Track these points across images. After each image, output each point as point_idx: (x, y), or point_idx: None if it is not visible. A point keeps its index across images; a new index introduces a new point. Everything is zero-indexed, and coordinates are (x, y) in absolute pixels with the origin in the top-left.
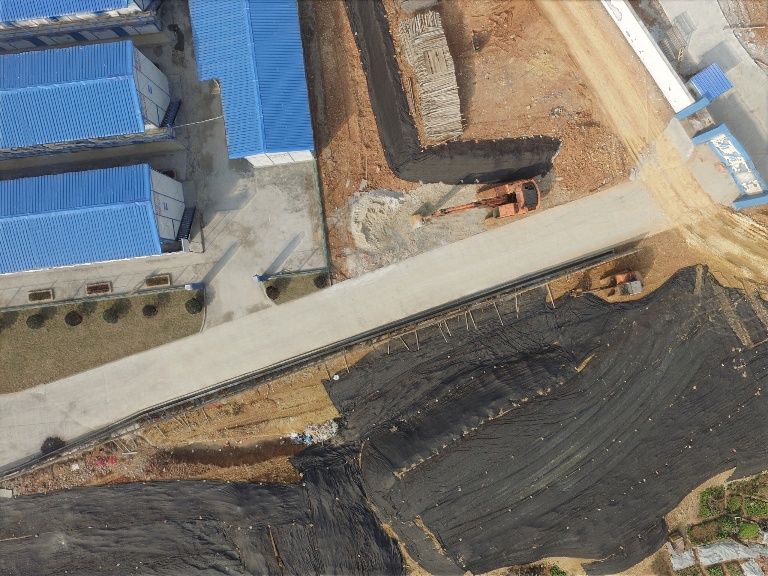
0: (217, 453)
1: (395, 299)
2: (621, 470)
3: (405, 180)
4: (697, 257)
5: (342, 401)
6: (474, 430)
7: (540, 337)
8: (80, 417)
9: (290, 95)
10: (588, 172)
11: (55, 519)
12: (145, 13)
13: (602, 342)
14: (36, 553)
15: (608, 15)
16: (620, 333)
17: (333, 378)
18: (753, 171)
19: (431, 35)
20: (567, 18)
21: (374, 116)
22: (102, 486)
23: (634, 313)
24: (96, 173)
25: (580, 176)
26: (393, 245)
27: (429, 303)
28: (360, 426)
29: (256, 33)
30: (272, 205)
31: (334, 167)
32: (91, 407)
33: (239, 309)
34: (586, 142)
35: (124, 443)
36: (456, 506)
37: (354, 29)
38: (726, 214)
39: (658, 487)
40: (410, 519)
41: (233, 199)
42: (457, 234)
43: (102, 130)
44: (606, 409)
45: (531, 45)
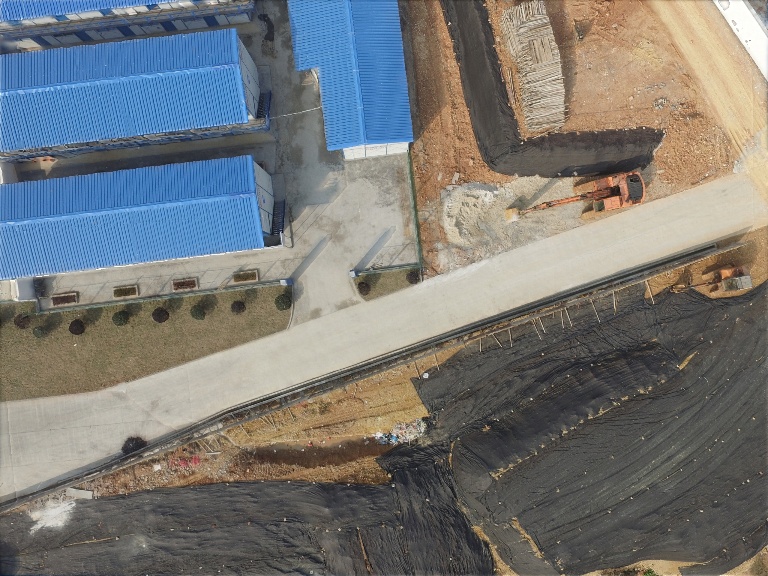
0: (300, 453)
1: (488, 295)
2: (724, 471)
3: (500, 173)
4: None
5: (432, 400)
6: (573, 429)
7: (638, 334)
8: (162, 416)
9: (390, 85)
10: (690, 165)
11: (136, 521)
12: (242, 1)
13: (705, 339)
14: (116, 556)
15: (713, 4)
16: (723, 330)
17: (423, 376)
18: None
19: (536, 24)
20: (671, 7)
21: (467, 108)
22: (185, 487)
23: (737, 309)
24: (198, 164)
25: (682, 169)
26: (486, 240)
27: (523, 299)
28: (449, 425)
29: (356, 22)
30: (363, 199)
31: (426, 160)
32: (174, 406)
33: (327, 305)
34: (689, 134)
35: (207, 443)
36: (554, 508)
37: (447, 19)
38: None
39: (762, 488)
40: (505, 521)
41: (323, 193)
42: (552, 228)
43: (205, 120)
44: (708, 408)
45: (634, 34)
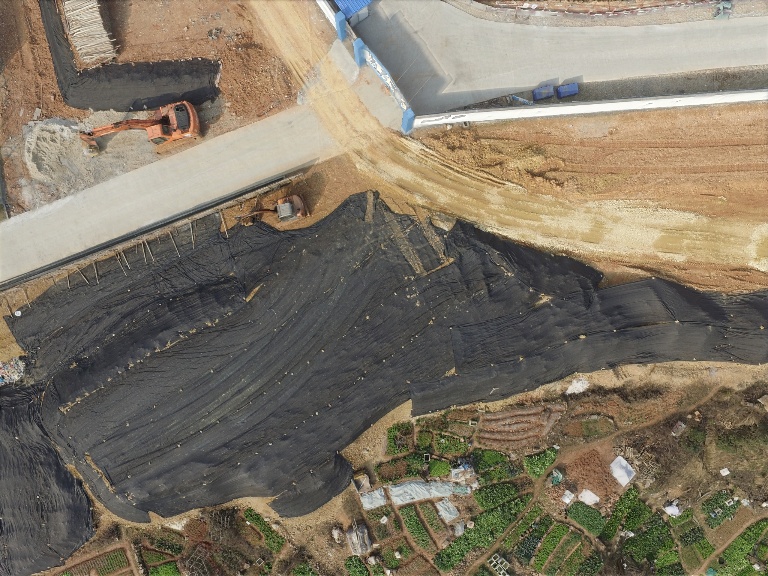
0: None
1: (74, 231)
2: (294, 403)
3: (75, 107)
4: (368, 183)
5: (25, 338)
6: (139, 362)
7: (217, 268)
8: None
9: None
10: (254, 96)
11: None
12: None
13: (271, 271)
14: None
15: None
16: (290, 262)
17: (15, 314)
18: (396, 88)
19: None
20: None
21: (48, 43)
22: None
23: (304, 241)
24: None
25: (247, 101)
26: (69, 175)
27: (107, 235)
28: (47, 364)
29: None
30: None
31: (7, 96)
32: None
33: None
34: (249, 65)
35: None
36: (124, 442)
37: None
38: (396, 138)
39: (331, 420)
40: (81, 456)
41: None
42: (132, 163)
43: None
44: (277, 340)
45: None
